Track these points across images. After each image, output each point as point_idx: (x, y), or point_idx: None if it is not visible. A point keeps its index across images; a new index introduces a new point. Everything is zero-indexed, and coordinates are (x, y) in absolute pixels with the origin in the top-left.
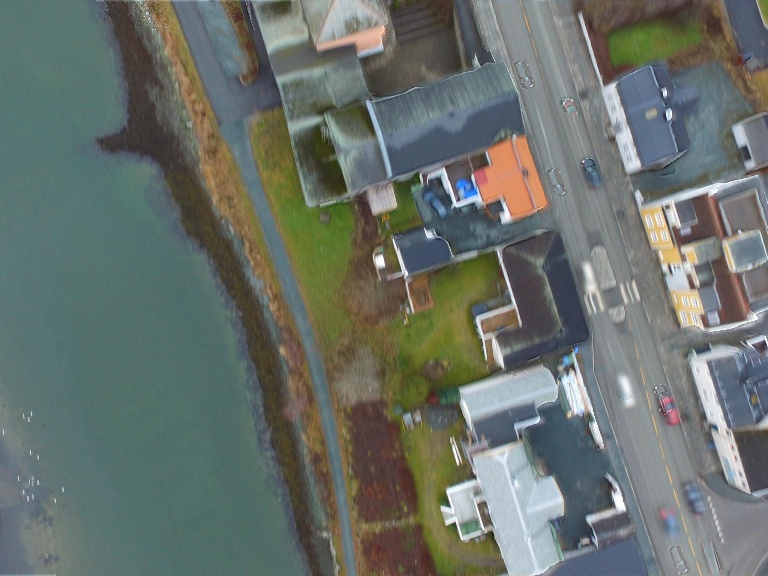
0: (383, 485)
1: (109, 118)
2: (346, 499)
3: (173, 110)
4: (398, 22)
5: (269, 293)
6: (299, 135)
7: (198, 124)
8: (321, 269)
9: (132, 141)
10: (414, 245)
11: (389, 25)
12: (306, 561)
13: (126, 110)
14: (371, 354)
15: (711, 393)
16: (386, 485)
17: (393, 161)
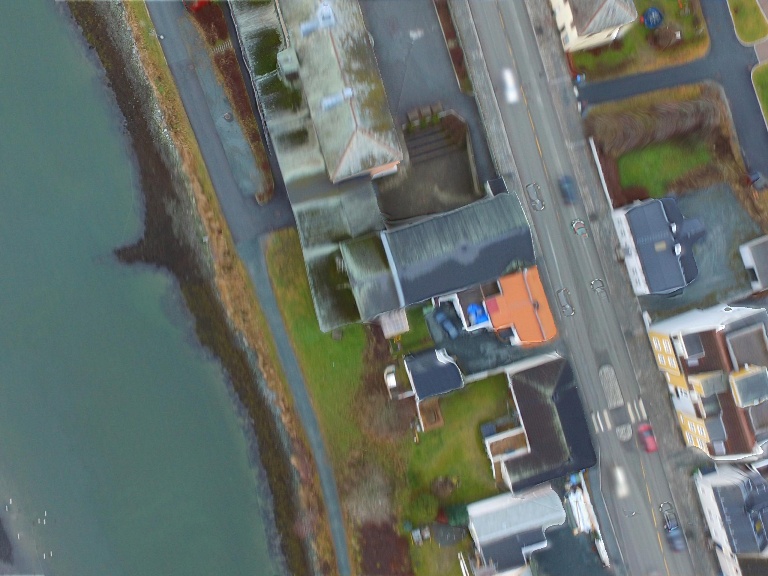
0: None
1: (126, 229)
2: None
3: (189, 224)
4: (412, 145)
5: (281, 405)
6: (314, 262)
7: (214, 240)
8: (333, 383)
9: (149, 253)
10: (425, 369)
11: (403, 148)
12: None
13: (143, 222)
14: (381, 468)
15: (716, 516)
16: None
17: (406, 292)
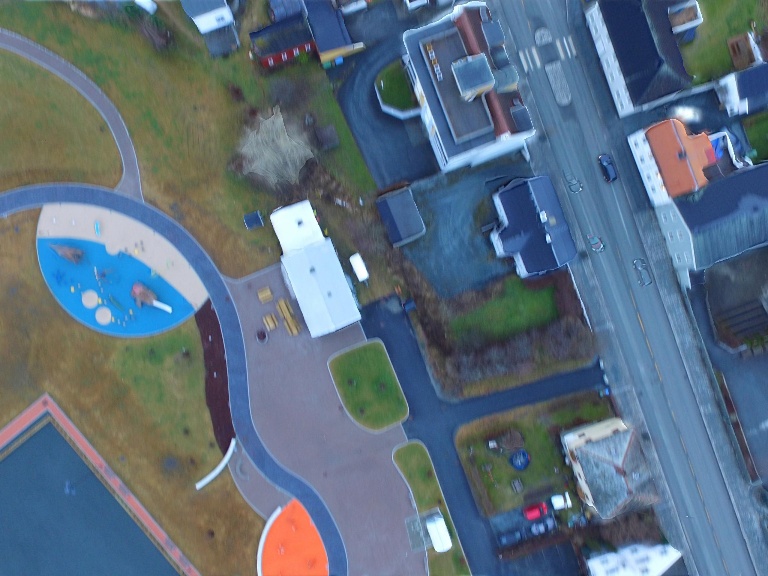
0: None
1: None
2: None
3: None
4: (764, 319)
5: None
6: None
7: None
8: None
9: None
10: (765, 92)
11: None
12: None
13: None
14: None
15: None
16: None
17: None
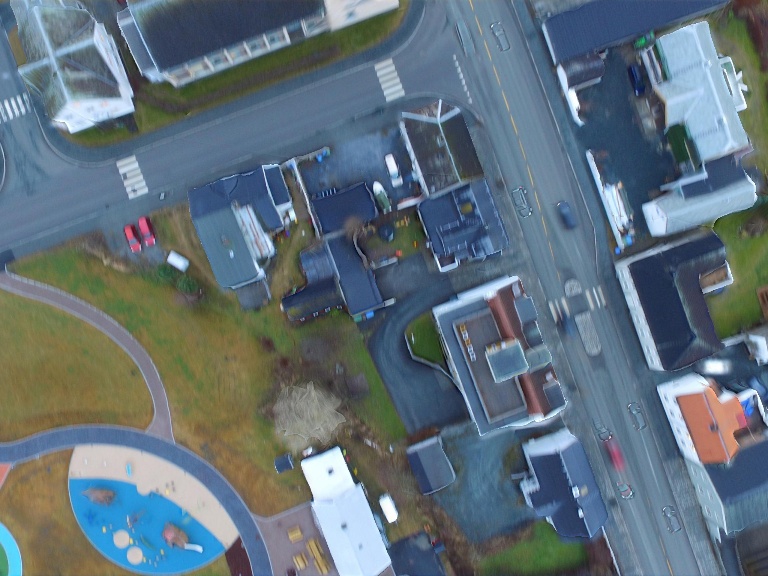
0: None
1: None
2: None
3: None
4: None
5: None
6: None
7: None
8: None
9: None
10: None
11: None
12: None
13: None
14: None
15: None
16: None
17: None
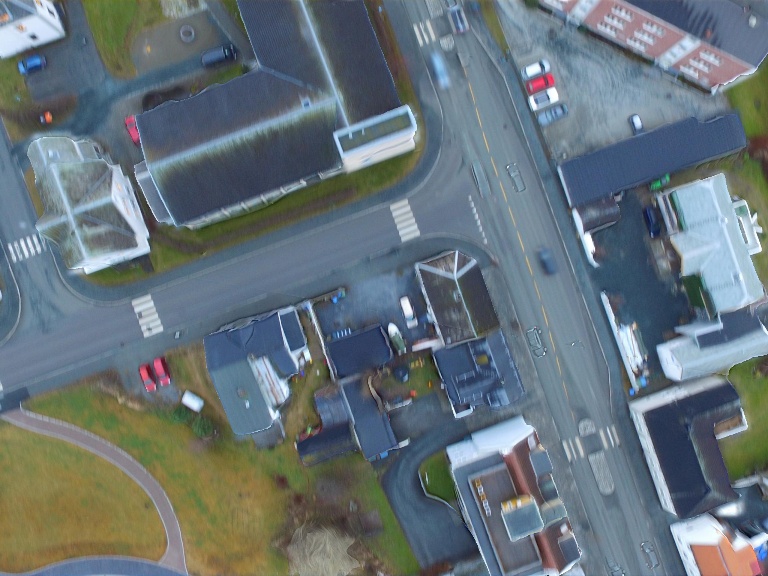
0: None
1: None
2: None
3: None
4: None
5: None
6: None
7: None
8: None
9: None
10: None
11: None
12: None
13: None
14: None
15: None
16: None
17: None
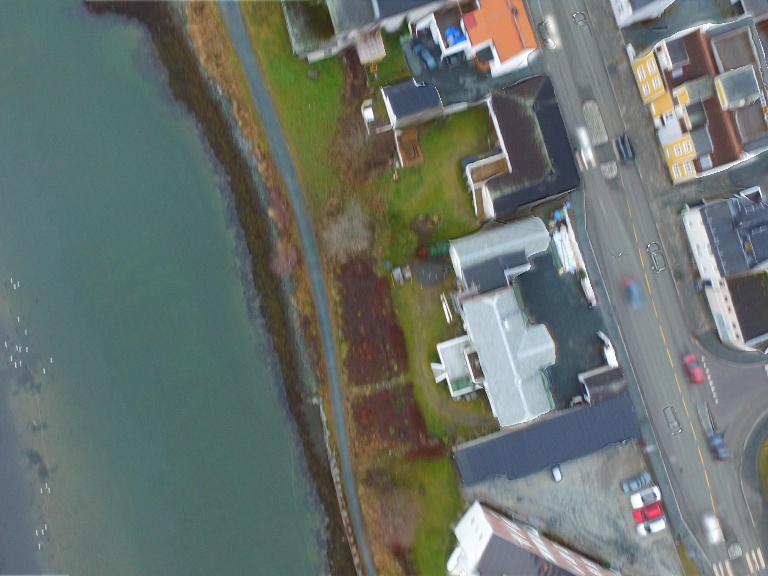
0: (373, 345)
1: None
2: (336, 363)
3: None
4: None
5: (257, 153)
6: None
7: None
8: (310, 127)
9: (119, 2)
10: (403, 93)
11: None
12: (296, 430)
13: None
14: (360, 213)
15: (704, 244)
16: (376, 345)
17: (381, 1)
